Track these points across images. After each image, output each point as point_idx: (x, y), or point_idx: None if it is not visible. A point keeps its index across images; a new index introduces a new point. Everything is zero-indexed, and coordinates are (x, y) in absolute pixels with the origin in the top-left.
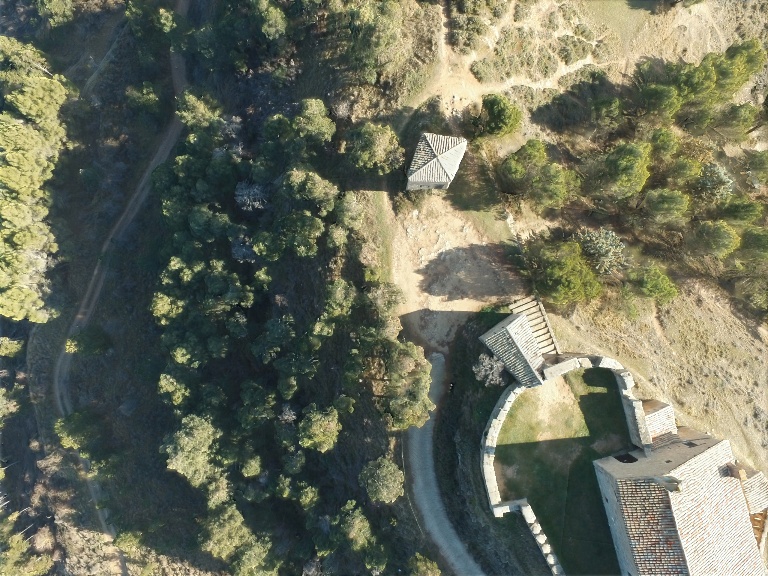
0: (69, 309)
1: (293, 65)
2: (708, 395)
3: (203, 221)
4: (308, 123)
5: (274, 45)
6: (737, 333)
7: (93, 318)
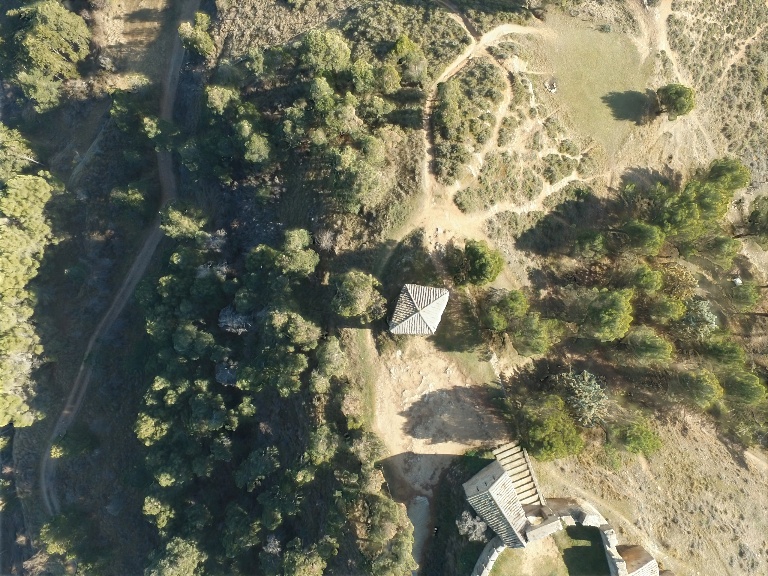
0: (55, 405)
1: (277, 182)
2: (693, 534)
3: (187, 344)
4: (290, 261)
5: (258, 164)
6: (723, 463)
7: (79, 415)
